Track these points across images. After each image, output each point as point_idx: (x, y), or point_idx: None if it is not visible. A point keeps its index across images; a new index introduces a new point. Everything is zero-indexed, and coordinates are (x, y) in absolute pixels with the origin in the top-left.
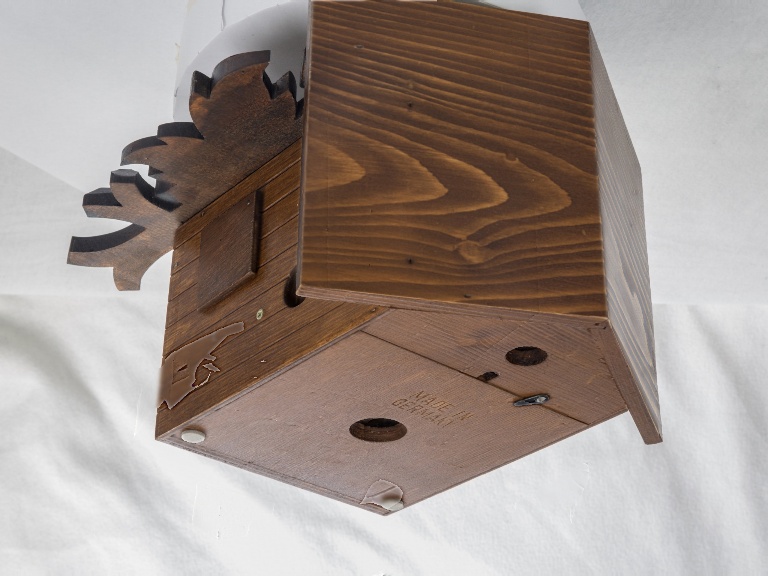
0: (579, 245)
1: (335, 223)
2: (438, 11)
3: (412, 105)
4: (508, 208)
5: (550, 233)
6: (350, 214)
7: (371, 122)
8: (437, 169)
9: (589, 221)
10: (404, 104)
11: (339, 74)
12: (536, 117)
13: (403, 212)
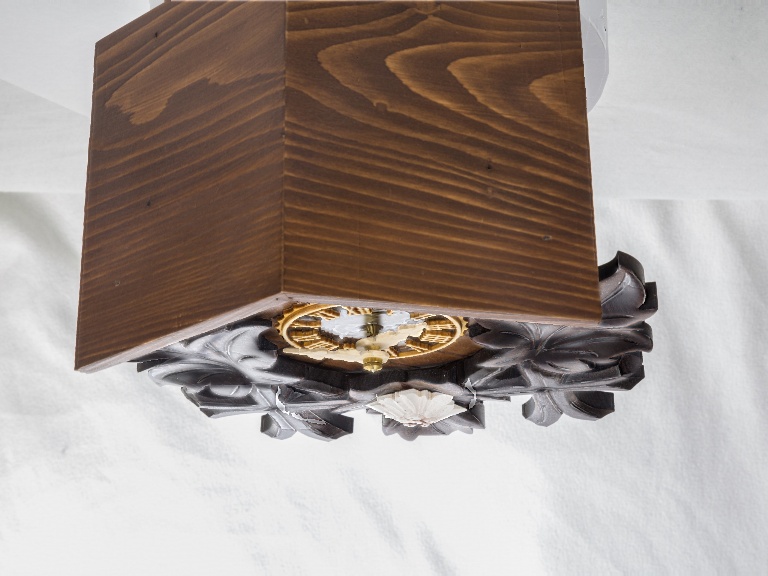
0: (313, 7)
1: (553, 34)
2: (464, 292)
3: (488, 167)
4: (386, 49)
5: (343, 21)
6: (540, 43)
7: (528, 145)
8: (459, 92)
9: (300, 33)
10: (496, 167)
11: (565, 202)
12: (353, 157)
13: (491, 45)
